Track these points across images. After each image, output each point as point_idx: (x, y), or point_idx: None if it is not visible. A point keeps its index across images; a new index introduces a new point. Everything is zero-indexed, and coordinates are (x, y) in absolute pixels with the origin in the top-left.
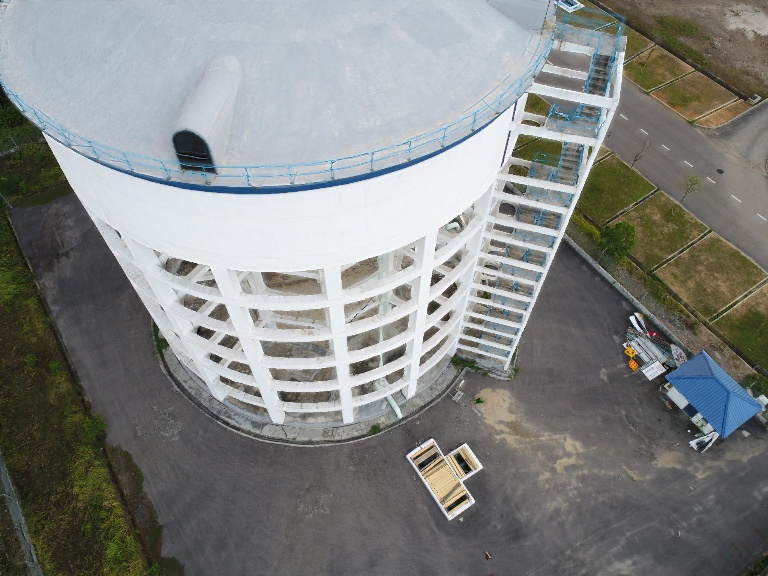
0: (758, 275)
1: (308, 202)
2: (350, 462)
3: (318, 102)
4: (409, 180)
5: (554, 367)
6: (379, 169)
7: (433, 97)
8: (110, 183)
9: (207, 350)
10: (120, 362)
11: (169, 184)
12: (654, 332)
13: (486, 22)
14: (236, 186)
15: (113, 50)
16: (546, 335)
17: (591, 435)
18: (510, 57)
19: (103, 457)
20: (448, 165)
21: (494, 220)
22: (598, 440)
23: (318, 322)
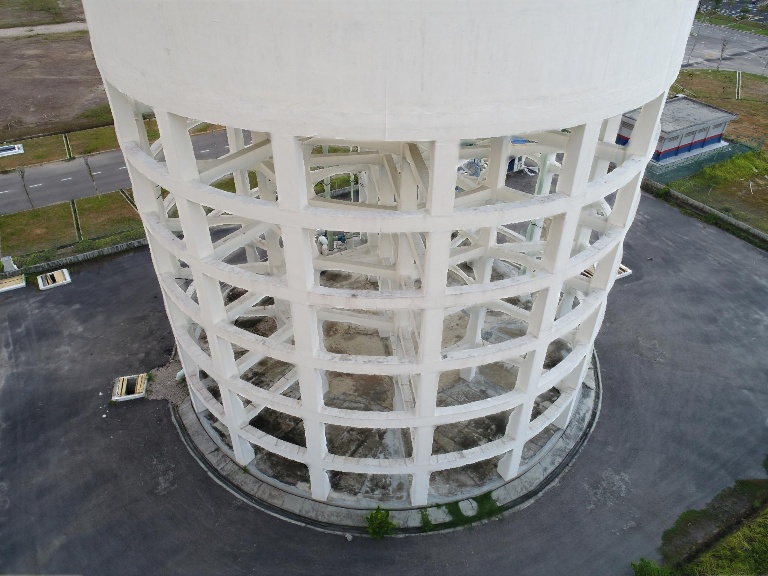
0: None
1: None
2: (602, 325)
3: None
4: None
5: None
6: None
7: None
8: None
9: None
10: (524, 572)
11: None
12: None
13: None
14: None
15: None
16: None
17: None
18: None
19: (683, 568)
20: None
21: None
22: None
23: None
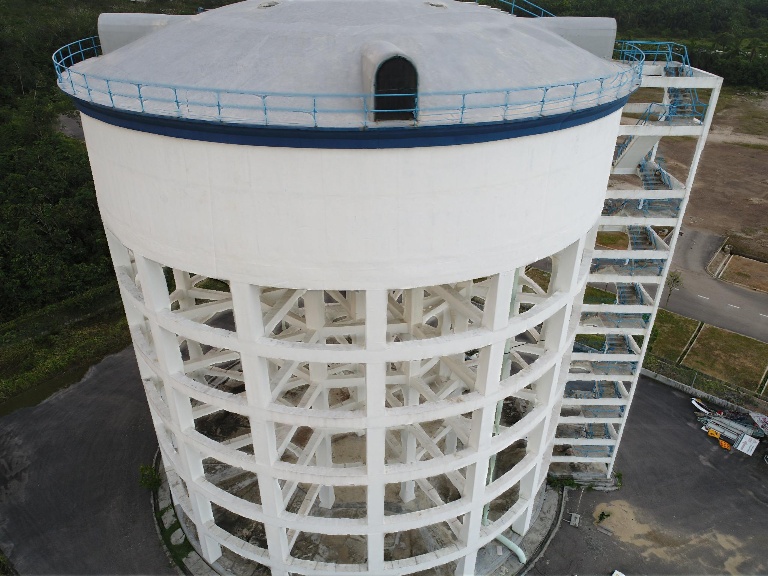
0: (767, 348)
1: (503, 162)
2: None
3: (487, 68)
4: (582, 147)
5: (653, 465)
6: (578, 109)
7: (580, 72)
8: (253, 183)
9: (306, 480)
10: None
11: (355, 146)
12: (721, 411)
13: (573, 44)
14: (448, 124)
15: (242, 56)
16: (625, 436)
17: (737, 525)
18: (607, 64)
19: None
20: (604, 140)
21: (600, 254)
22: (748, 528)
23: (392, 461)
